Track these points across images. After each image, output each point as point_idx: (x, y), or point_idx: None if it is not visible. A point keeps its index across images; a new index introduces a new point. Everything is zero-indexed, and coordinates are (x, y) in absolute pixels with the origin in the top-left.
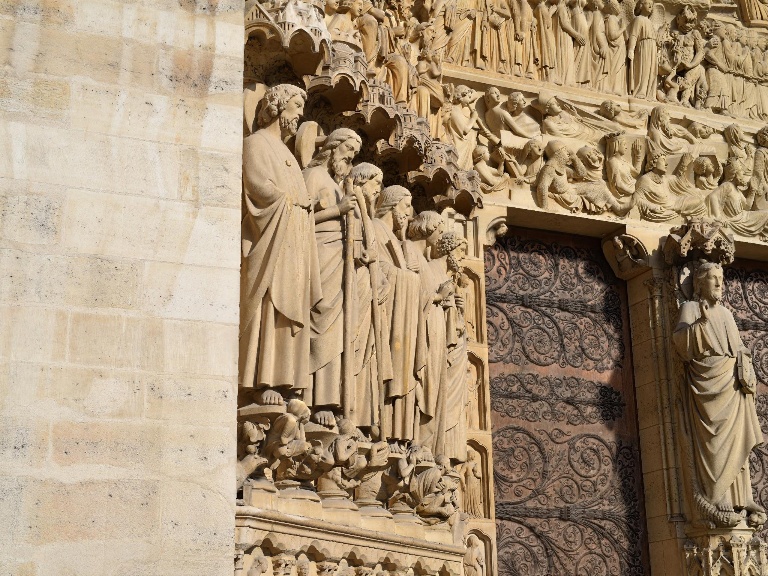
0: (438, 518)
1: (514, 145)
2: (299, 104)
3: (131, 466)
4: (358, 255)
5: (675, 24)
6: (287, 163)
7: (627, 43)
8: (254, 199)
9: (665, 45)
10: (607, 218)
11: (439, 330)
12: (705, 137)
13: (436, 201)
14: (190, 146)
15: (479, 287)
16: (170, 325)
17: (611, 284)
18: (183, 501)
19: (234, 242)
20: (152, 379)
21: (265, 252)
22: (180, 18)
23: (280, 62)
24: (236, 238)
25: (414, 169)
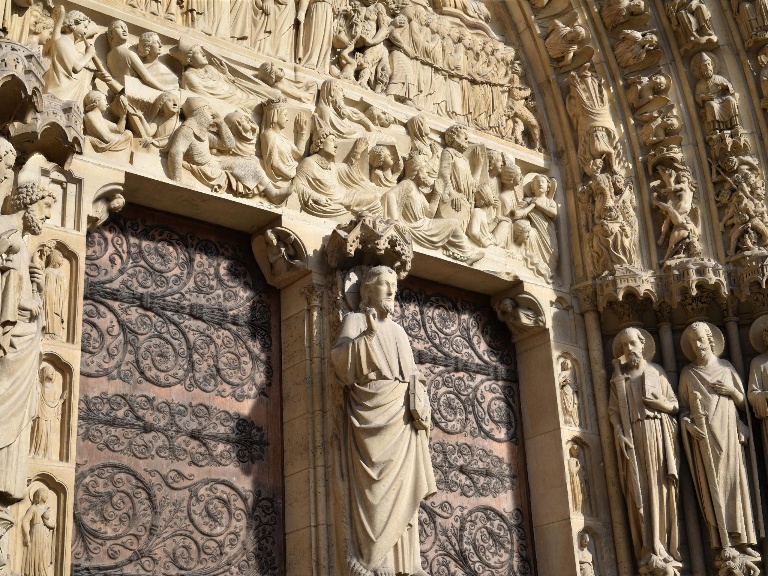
0: None
1: (142, 96)
2: None
3: None
4: None
5: None
6: None
7: (297, 4)
8: None
9: (343, 16)
10: (258, 204)
11: None
12: (384, 125)
13: (13, 133)
14: None
15: (76, 269)
16: None
17: (260, 292)
18: None
19: None
20: None
21: None
22: None
23: None
24: None
25: None
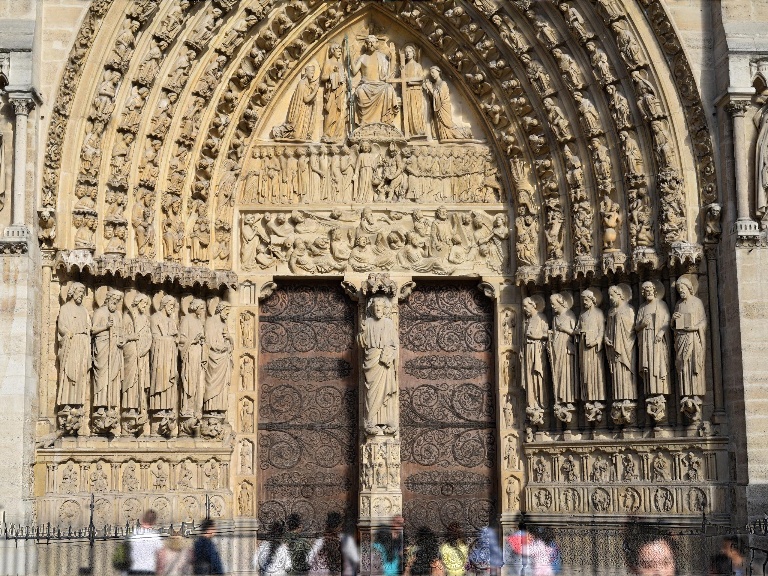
0: (210, 437)
1: (278, 242)
2: (80, 291)
3: None
4: (119, 343)
5: (389, 152)
6: (74, 317)
7: None
8: None
9: (382, 166)
10: (333, 274)
11: (196, 356)
12: (399, 219)
13: (211, 288)
14: (8, 334)
15: (255, 320)
16: (1, 397)
17: (349, 304)
18: (5, 454)
19: (23, 366)
20: None
21: None
22: (4, 287)
23: None
24: (24, 365)
25: None
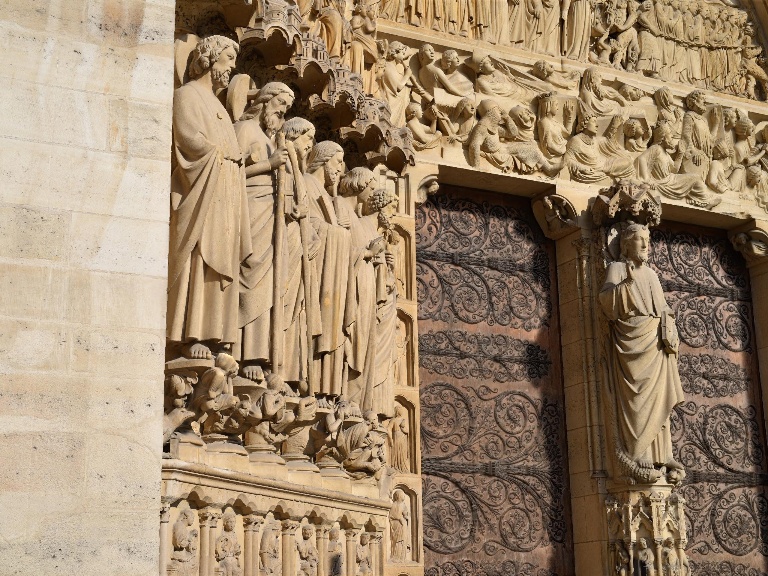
0: (365, 473)
1: (447, 103)
2: (231, 56)
3: (56, 418)
4: (289, 210)
5: None
6: (218, 116)
7: (561, 4)
8: (184, 152)
9: (598, 7)
10: (537, 178)
11: (369, 286)
12: (635, 100)
13: (368, 157)
14: (119, 96)
15: (410, 244)
16: (97, 277)
17: (540, 244)
18: (109, 454)
19: (163, 195)
20: (78, 331)
21: (195, 205)
22: None
23: (212, 13)
24: (165, 191)
25: (347, 125)
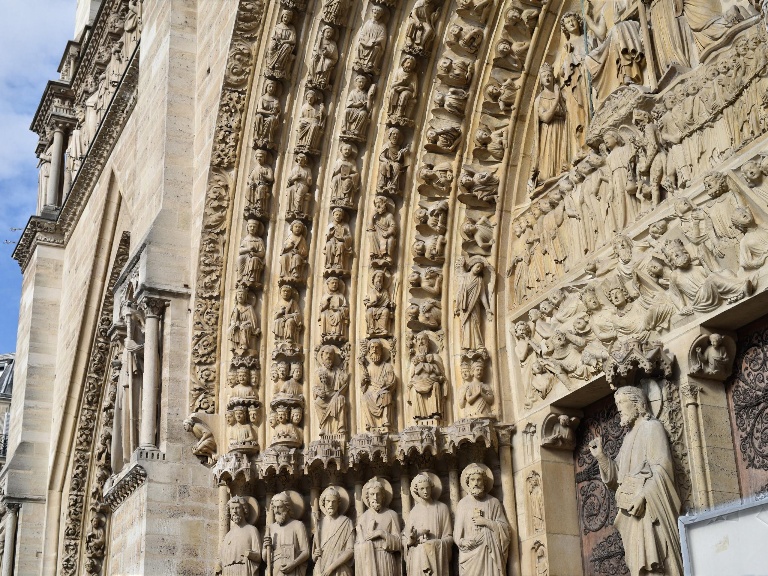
0: None
1: None
2: (232, 508)
3: None
4: None
5: None
6: None
7: None
8: None
9: None
10: None
11: (416, 564)
12: (664, 232)
13: None
14: None
15: None
16: None
17: None
18: None
19: None
20: None
21: None
22: None
23: None
24: None
25: None
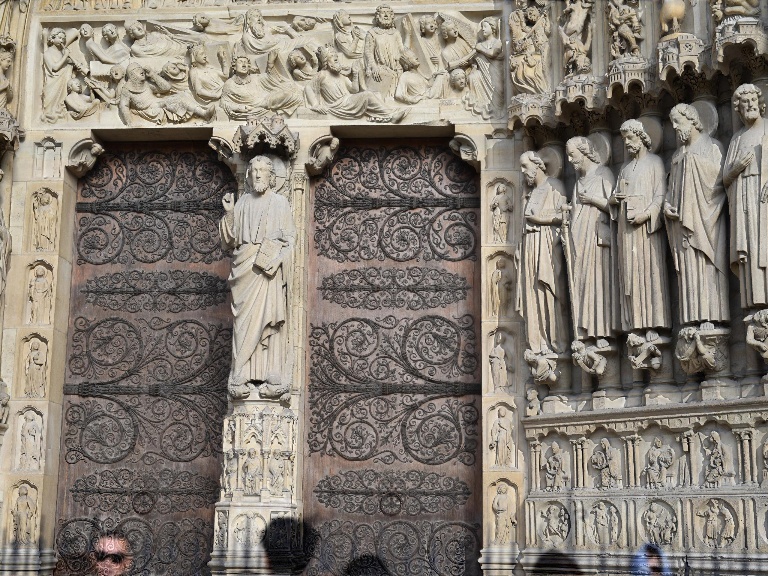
0: None
1: (102, 73)
2: None
3: None
4: None
5: None
6: None
7: None
8: None
9: None
10: (193, 125)
11: None
12: (309, 29)
13: None
14: None
15: (57, 204)
16: None
17: (229, 181)
18: None
19: None
20: None
21: None
22: None
23: None
24: None
25: None
